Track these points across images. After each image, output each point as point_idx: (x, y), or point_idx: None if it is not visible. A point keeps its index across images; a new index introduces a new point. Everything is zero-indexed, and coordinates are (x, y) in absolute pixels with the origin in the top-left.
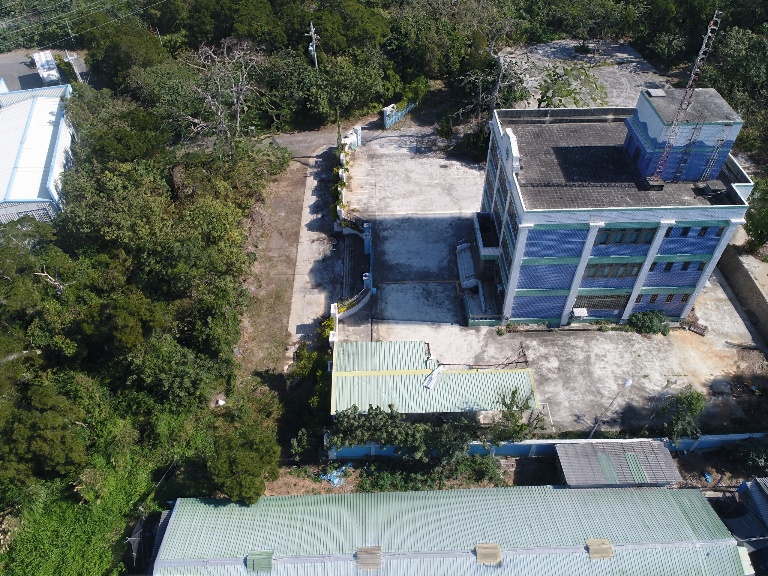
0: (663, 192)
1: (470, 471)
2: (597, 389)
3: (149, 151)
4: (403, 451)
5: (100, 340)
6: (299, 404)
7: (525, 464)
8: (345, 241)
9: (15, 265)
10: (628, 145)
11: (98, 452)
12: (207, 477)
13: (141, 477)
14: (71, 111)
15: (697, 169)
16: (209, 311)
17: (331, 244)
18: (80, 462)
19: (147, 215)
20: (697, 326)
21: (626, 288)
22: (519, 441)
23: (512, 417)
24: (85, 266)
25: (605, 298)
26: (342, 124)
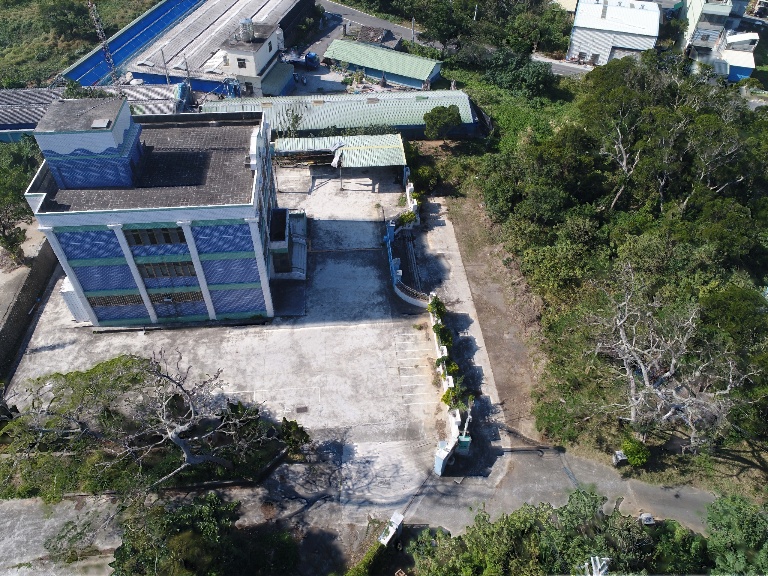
0: None
1: None
2: None
3: None
4: None
5: None
6: None
7: None
8: None
9: (671, 167)
10: None
11: None
12: None
13: None
14: None
15: None
16: None
17: None
18: None
19: None
20: None
21: None
22: None
23: None
24: None
25: None
26: None
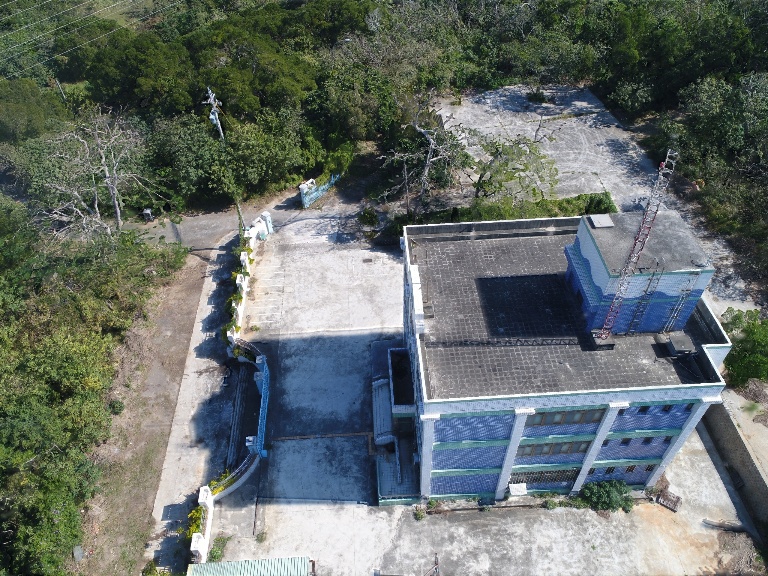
0: (614, 352)
1: None
2: None
3: (1, 263)
4: None
5: None
6: None
7: None
8: (239, 372)
9: None
10: (571, 276)
11: None
12: None
13: None
14: None
15: (657, 320)
16: (34, 513)
17: (222, 377)
18: None
19: None
20: (667, 497)
21: (574, 463)
22: None
23: None
24: None
25: (548, 473)
26: (255, 202)
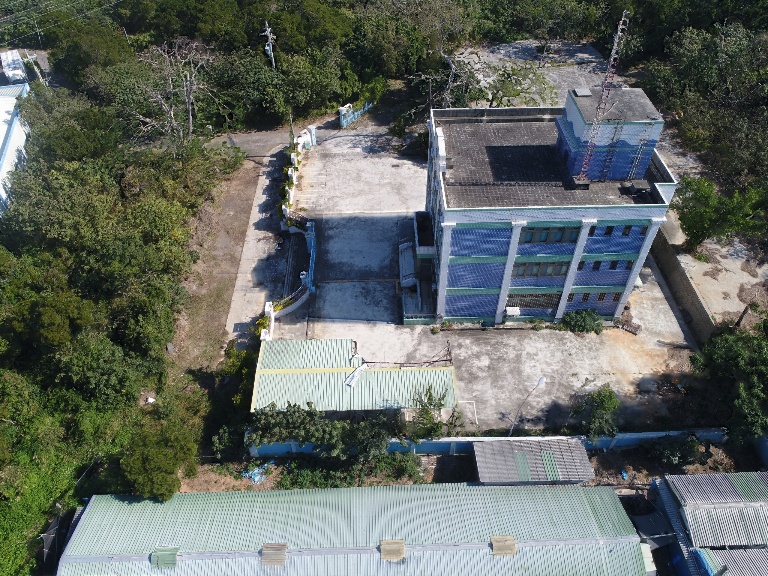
0: (589, 191)
1: (390, 468)
2: (525, 387)
3: (98, 150)
4: (322, 448)
5: (35, 338)
6: (226, 402)
7: (446, 462)
8: (291, 240)
9: None
10: (560, 144)
11: (23, 449)
12: (121, 474)
13: (63, 474)
14: (25, 110)
15: (623, 168)
16: (142, 309)
17: (277, 243)
18: (4, 459)
19: (92, 214)
20: (630, 325)
21: (557, 287)
22: (437, 439)
23: (426, 415)
24: (27, 264)
25: (537, 297)
26: (300, 123)
